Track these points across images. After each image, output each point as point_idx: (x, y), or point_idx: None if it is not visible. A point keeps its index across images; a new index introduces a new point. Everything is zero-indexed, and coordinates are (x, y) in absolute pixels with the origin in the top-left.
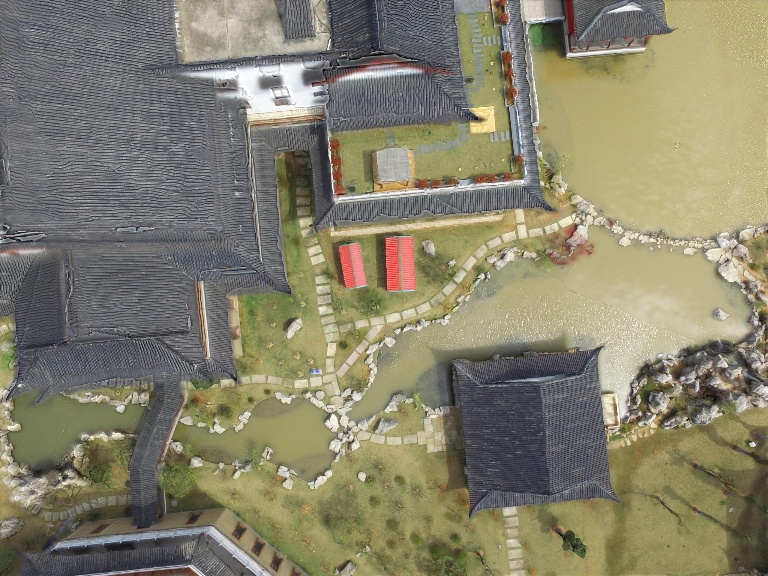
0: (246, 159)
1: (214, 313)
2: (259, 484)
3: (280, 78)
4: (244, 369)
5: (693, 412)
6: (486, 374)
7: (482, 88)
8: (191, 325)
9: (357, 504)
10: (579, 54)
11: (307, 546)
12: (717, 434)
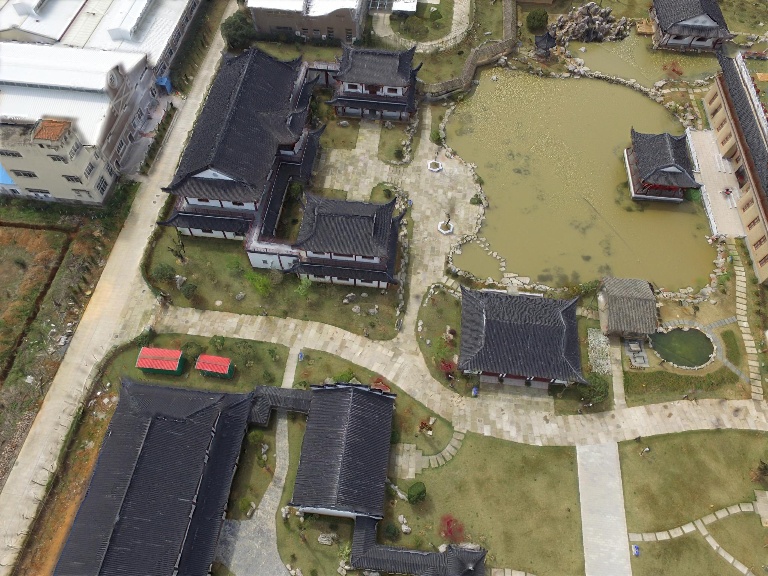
0: None
1: None
2: None
3: None
4: None
5: None
6: (718, 32)
7: (766, 88)
8: None
9: (762, 17)
10: None
11: None
12: None
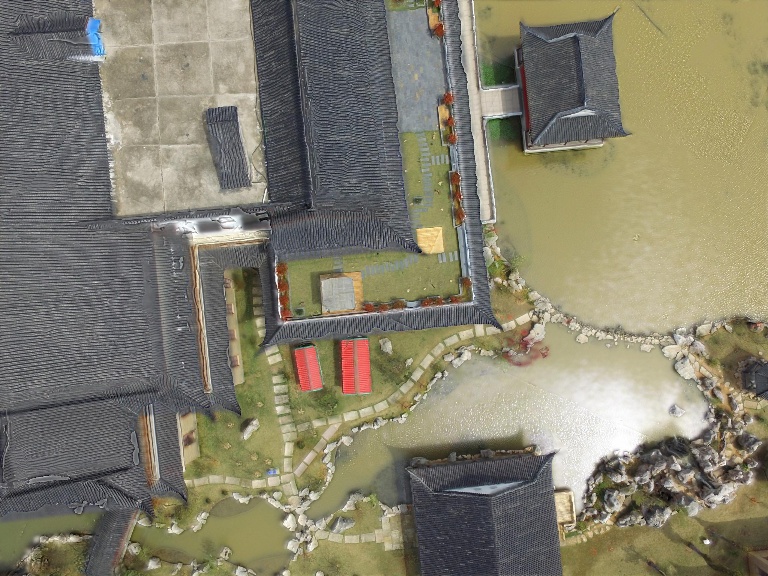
0: (193, 283)
1: (164, 433)
2: None
3: None
4: (202, 470)
5: (647, 513)
6: (440, 480)
7: (430, 208)
8: (139, 451)
9: None
10: (536, 151)
11: None
12: (672, 530)
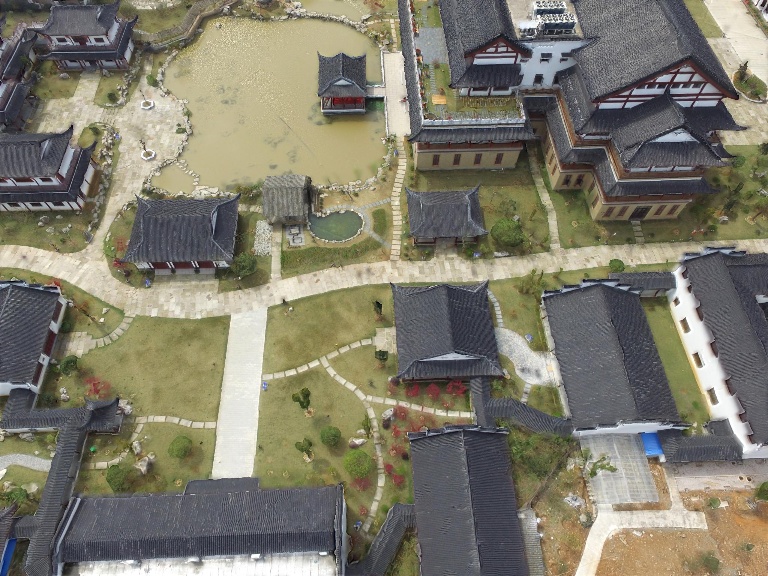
0: None
1: None
2: None
3: None
4: None
5: None
6: None
7: (423, 6)
8: None
9: None
10: None
11: None
12: None
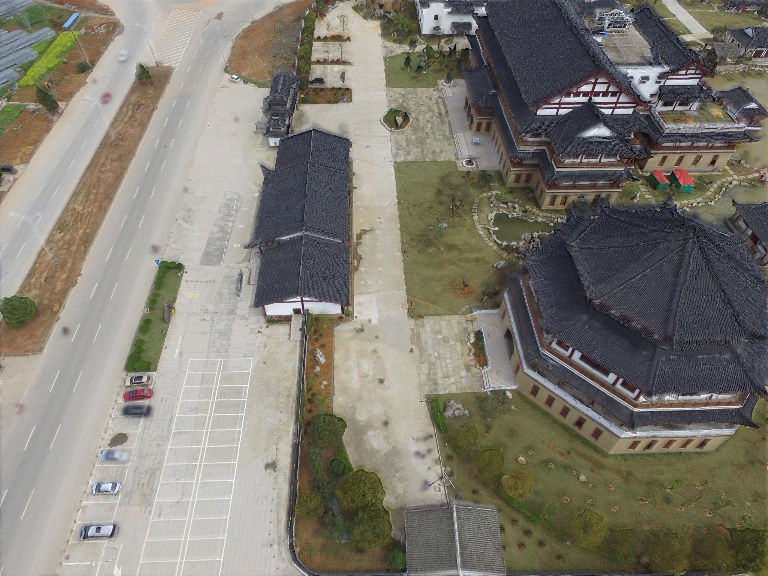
0: None
1: None
2: None
3: (642, 88)
4: None
5: None
6: None
7: None
8: None
9: None
10: None
11: None
12: None
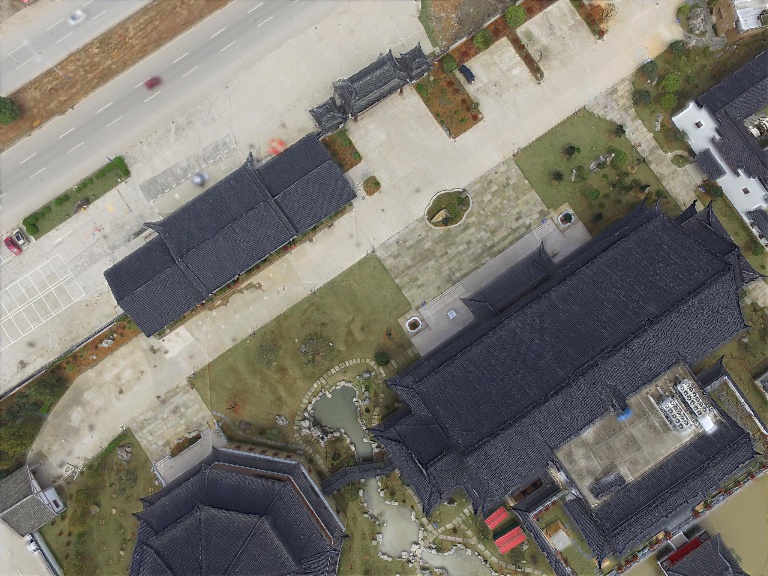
0: None
1: None
2: (367, 528)
3: None
4: None
5: None
6: None
7: None
8: None
9: None
10: (662, 568)
11: (350, 568)
12: None
